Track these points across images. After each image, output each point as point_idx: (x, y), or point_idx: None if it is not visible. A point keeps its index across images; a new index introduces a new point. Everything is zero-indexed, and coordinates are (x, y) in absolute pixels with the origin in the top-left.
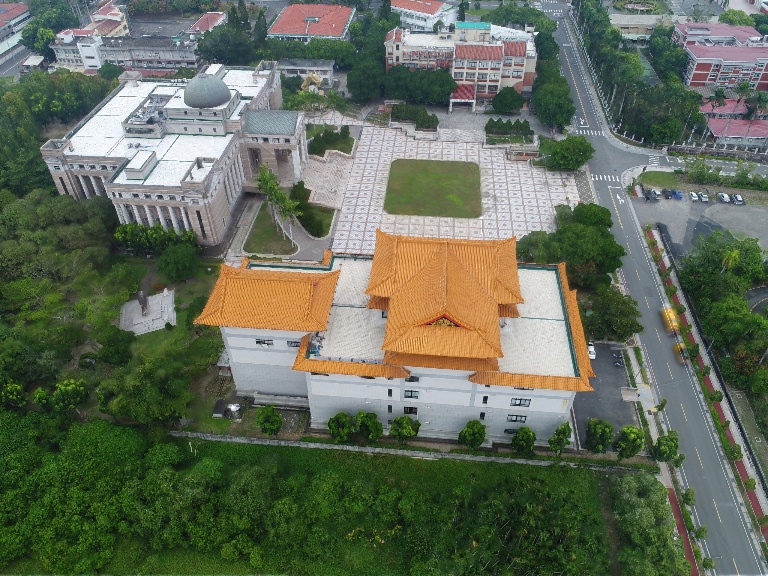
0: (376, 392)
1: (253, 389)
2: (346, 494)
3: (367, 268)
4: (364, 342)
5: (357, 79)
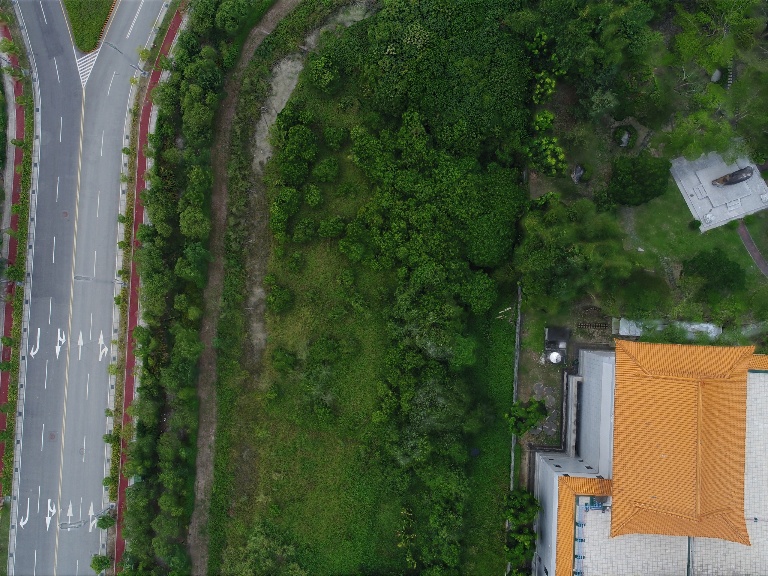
0: (555, 567)
1: (585, 375)
2: (449, 506)
3: None
4: (616, 571)
5: None
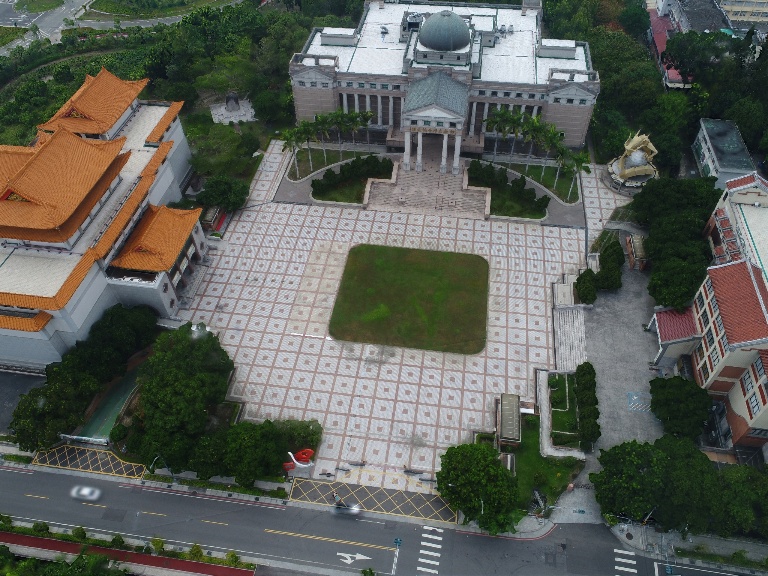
0: None
1: None
2: None
3: (135, 166)
4: None
5: (652, 183)
